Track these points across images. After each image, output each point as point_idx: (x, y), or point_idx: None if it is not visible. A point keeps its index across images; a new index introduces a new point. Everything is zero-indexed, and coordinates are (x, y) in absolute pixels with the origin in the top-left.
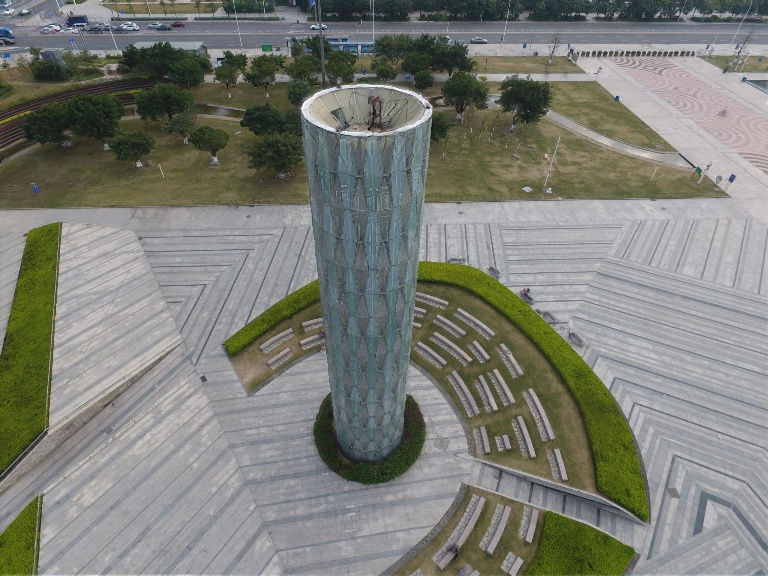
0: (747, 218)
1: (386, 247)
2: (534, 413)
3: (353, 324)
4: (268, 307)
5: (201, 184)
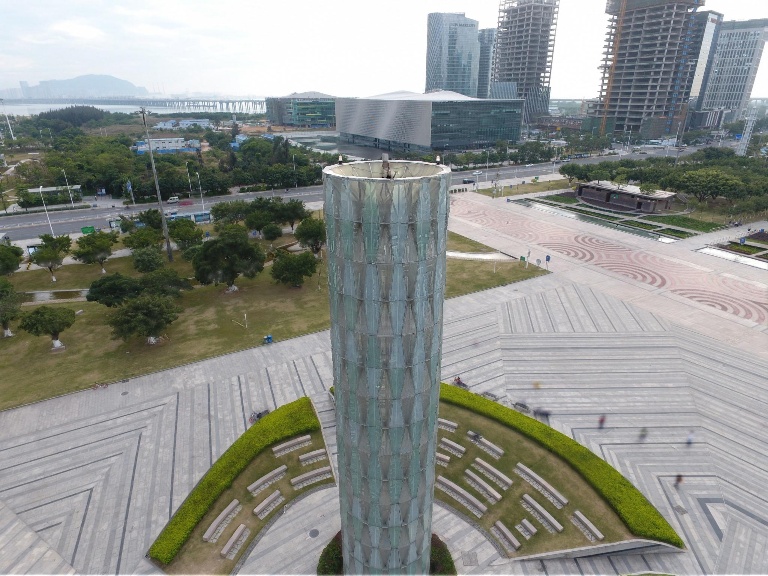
0: (572, 283)
1: (430, 302)
2: (535, 485)
3: (395, 412)
4: (193, 486)
5: (44, 374)
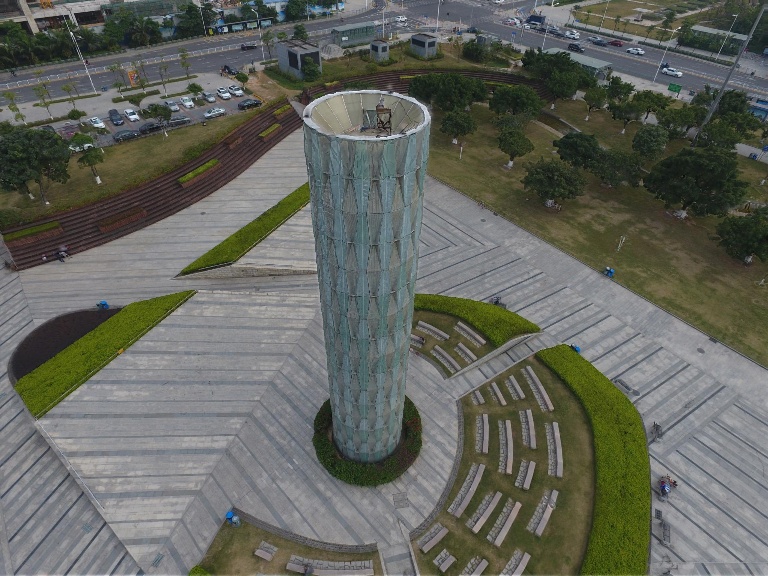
0: None
1: None
2: (503, 575)
3: None
4: None
5: (479, 177)
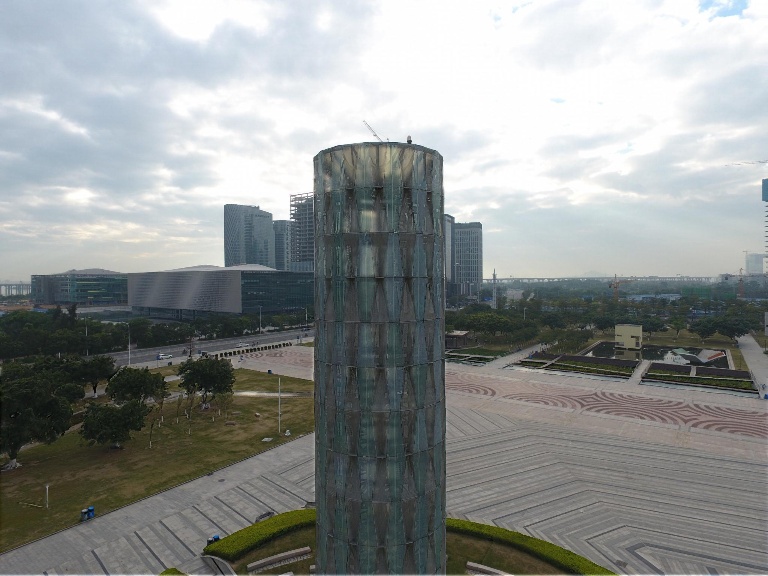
0: None
1: None
2: None
3: (417, 430)
4: None
5: None
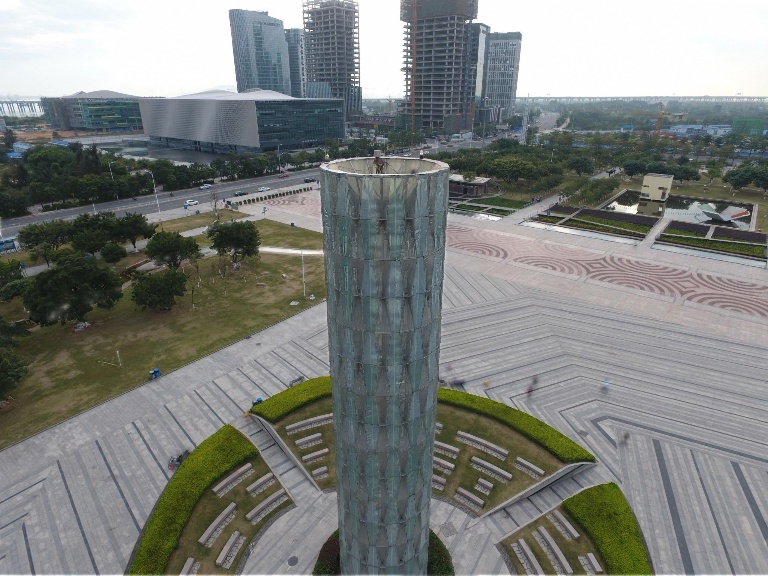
0: None
1: None
2: (478, 447)
3: (412, 404)
4: (125, 562)
5: None
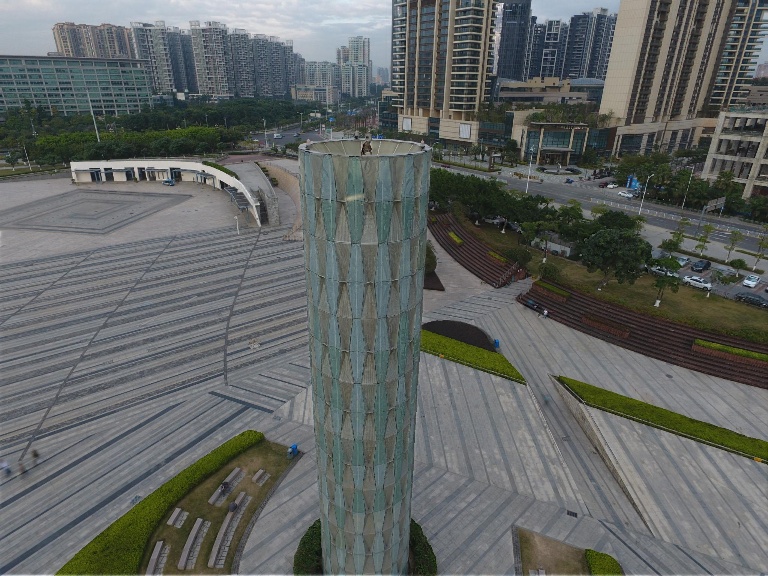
0: None
1: None
2: None
3: None
4: None
5: None
